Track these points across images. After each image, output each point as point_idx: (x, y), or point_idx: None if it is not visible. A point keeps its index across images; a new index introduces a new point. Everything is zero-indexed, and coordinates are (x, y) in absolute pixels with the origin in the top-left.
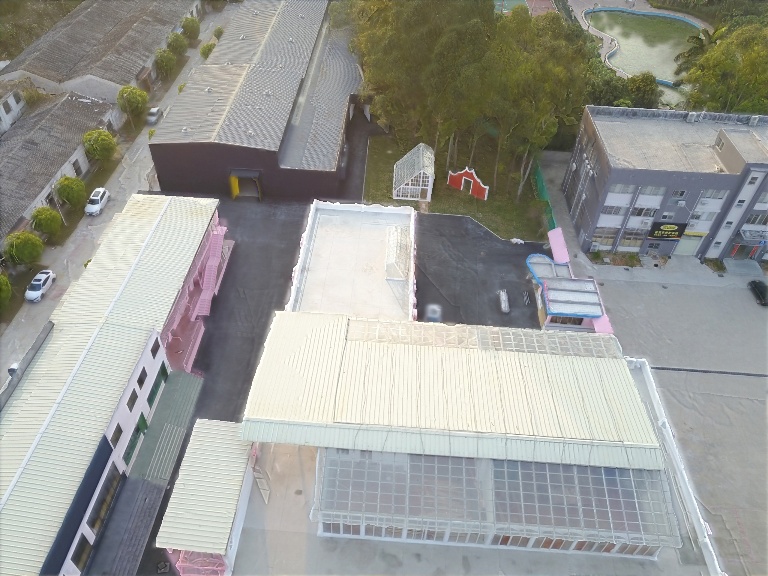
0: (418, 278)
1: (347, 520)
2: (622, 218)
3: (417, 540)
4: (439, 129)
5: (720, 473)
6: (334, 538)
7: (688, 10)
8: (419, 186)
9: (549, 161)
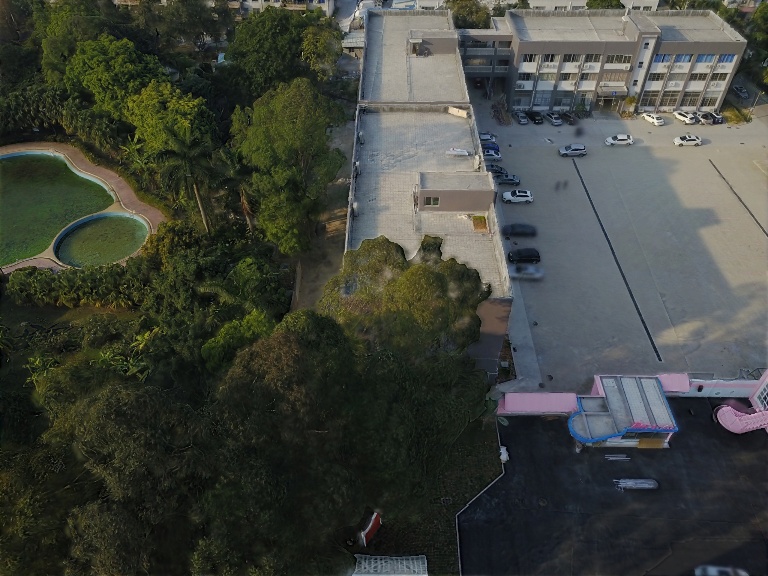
0: None
1: None
2: None
3: None
4: None
5: (764, 341)
6: None
7: None
8: None
9: None
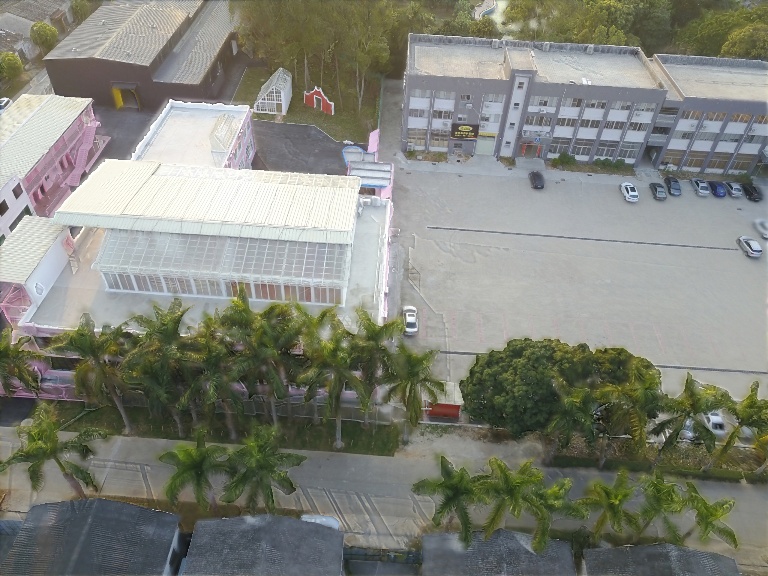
0: (257, 165)
1: (117, 269)
2: (427, 120)
3: (176, 294)
4: (283, 49)
5: (452, 290)
6: (116, 292)
7: None
8: (274, 101)
9: (399, 89)
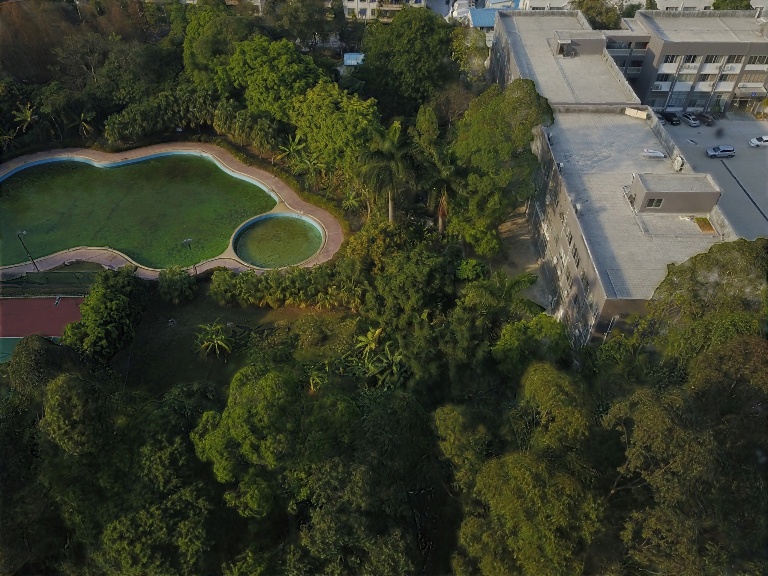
0: None
1: None
2: None
3: None
4: None
5: None
6: None
7: (10, 153)
8: None
9: None
